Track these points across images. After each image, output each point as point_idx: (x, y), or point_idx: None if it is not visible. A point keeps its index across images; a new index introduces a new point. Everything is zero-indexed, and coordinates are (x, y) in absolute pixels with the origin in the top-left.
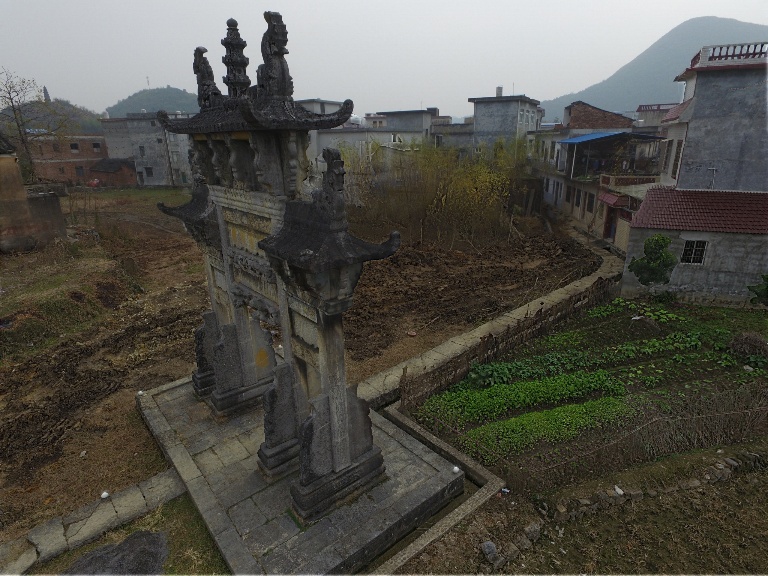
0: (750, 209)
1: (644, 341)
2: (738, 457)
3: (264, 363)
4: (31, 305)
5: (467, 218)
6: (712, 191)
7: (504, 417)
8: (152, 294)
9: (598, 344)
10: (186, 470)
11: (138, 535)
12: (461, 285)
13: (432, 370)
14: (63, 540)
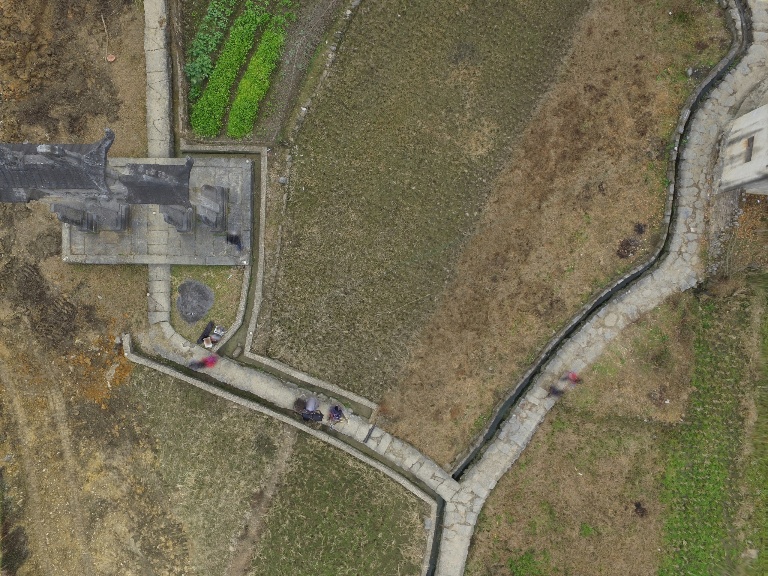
0: None
1: None
2: (334, 41)
3: None
4: None
5: None
6: None
7: (232, 97)
8: None
9: None
10: (157, 260)
11: (182, 288)
12: None
13: (169, 95)
14: (164, 313)
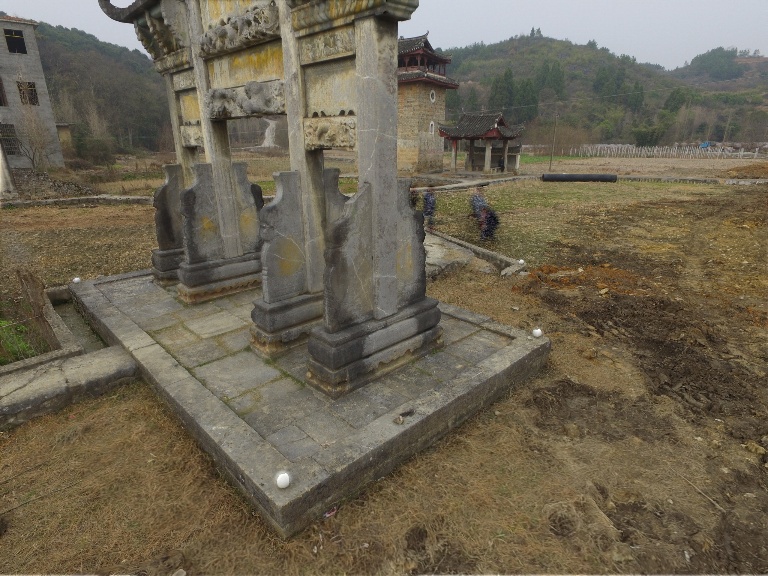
0: None
1: None
2: None
3: None
4: None
5: None
6: None
7: None
8: None
9: None
10: None
11: None
12: None
13: None
14: None
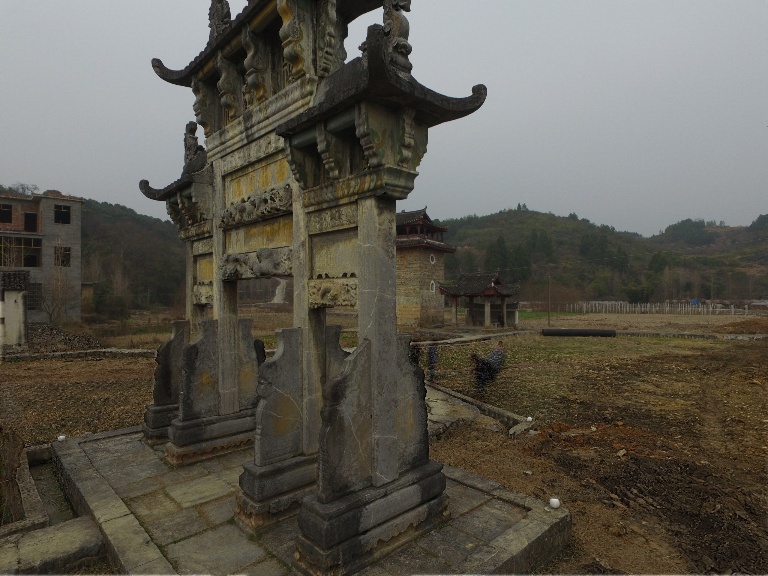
0: None
1: None
2: None
3: None
4: None
5: None
6: None
7: None
8: None
9: None
10: None
11: None
12: None
13: None
14: None
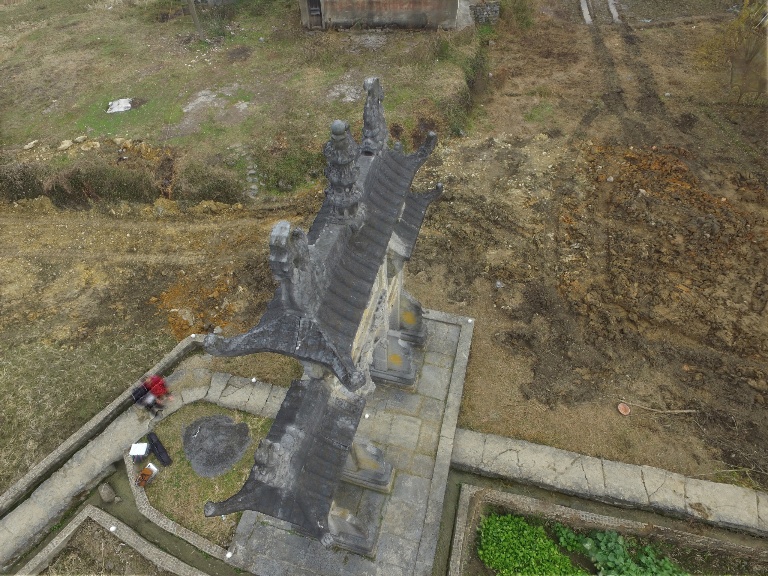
0: None
1: None
2: None
3: (397, 363)
4: (358, 130)
5: None
6: None
7: None
8: (466, 143)
9: None
10: None
11: (242, 429)
12: None
13: (562, 488)
14: (219, 396)
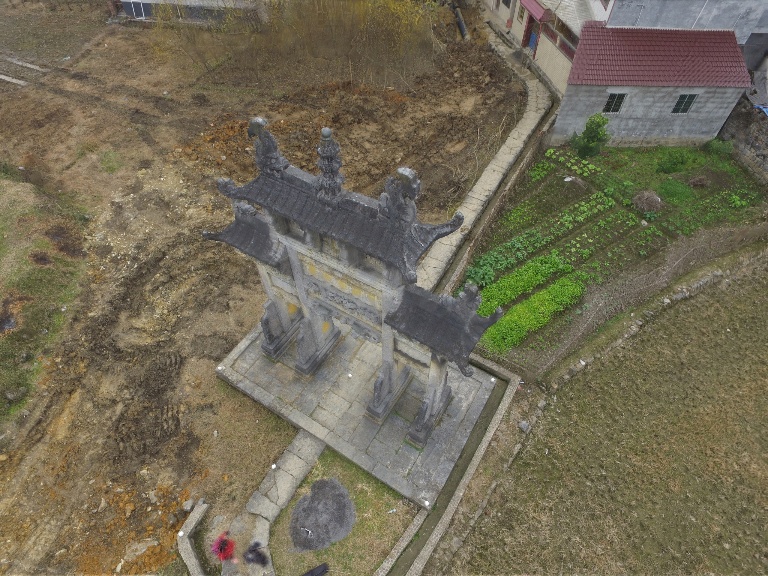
0: (664, 54)
1: (576, 206)
2: (643, 317)
3: (327, 329)
4: (8, 289)
5: (395, 46)
6: (636, 28)
7: None
8: (102, 220)
9: (544, 215)
10: (316, 430)
11: (319, 485)
12: (414, 151)
13: (437, 281)
14: (275, 505)
